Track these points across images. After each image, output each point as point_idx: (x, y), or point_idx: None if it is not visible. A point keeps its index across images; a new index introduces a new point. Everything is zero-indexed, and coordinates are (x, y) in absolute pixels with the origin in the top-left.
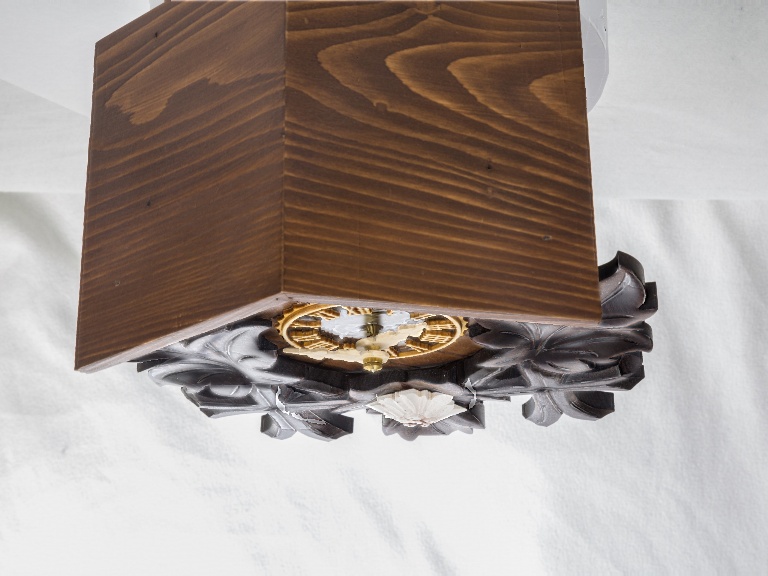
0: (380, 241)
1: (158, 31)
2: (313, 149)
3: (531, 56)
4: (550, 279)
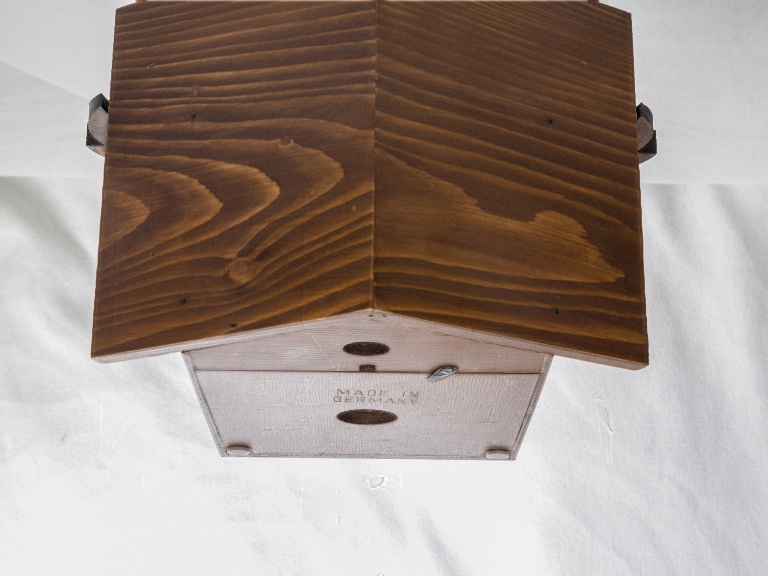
0: (293, 8)
1: (555, 313)
2: (349, 74)
3: (144, 247)
4: (153, 29)
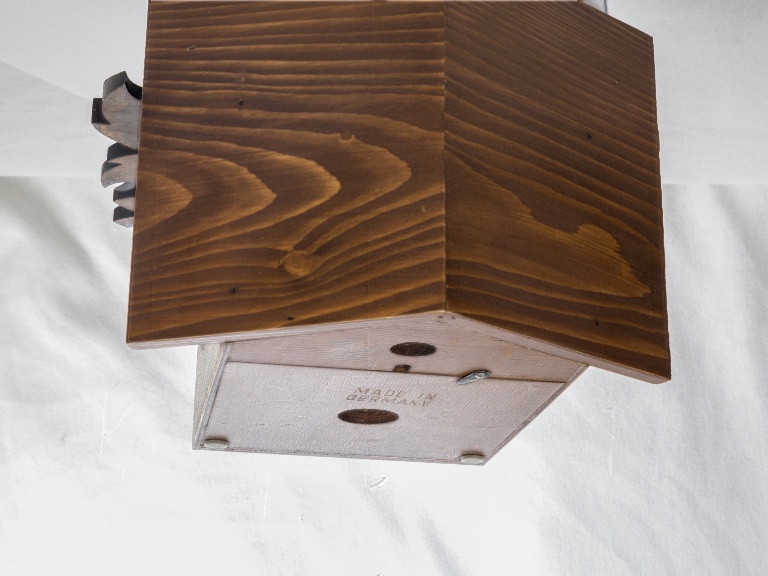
0: (352, 3)
1: (595, 324)
2: (416, 74)
3: (187, 233)
4: (193, 10)
